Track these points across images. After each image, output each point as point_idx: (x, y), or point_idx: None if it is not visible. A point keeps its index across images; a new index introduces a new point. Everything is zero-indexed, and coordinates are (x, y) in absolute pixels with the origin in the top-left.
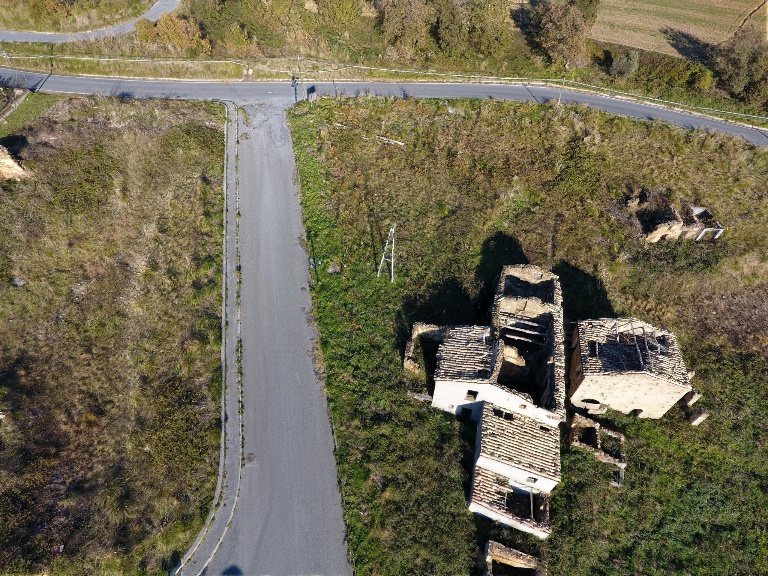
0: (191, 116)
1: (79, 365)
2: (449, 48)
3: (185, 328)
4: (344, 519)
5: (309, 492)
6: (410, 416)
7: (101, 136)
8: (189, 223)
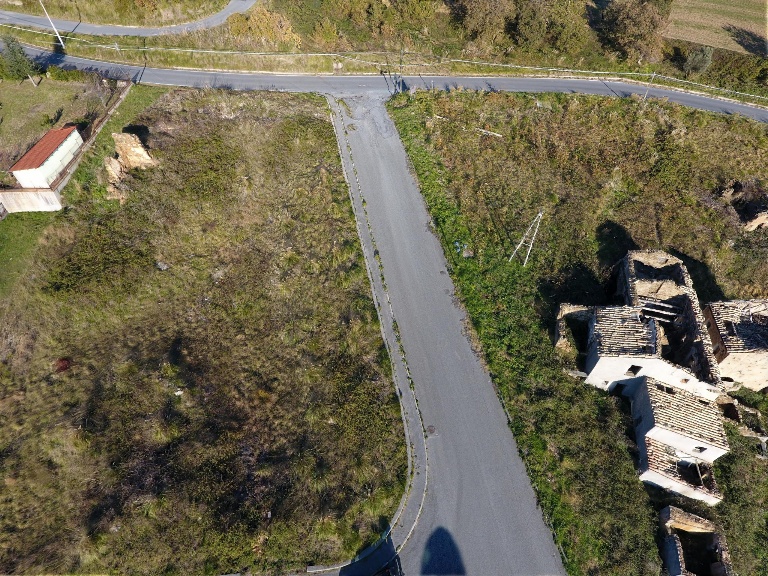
0: (299, 108)
1: (236, 345)
2: (526, 44)
3: (341, 309)
4: (533, 486)
5: (494, 461)
6: (569, 391)
7: (216, 126)
8: (320, 210)
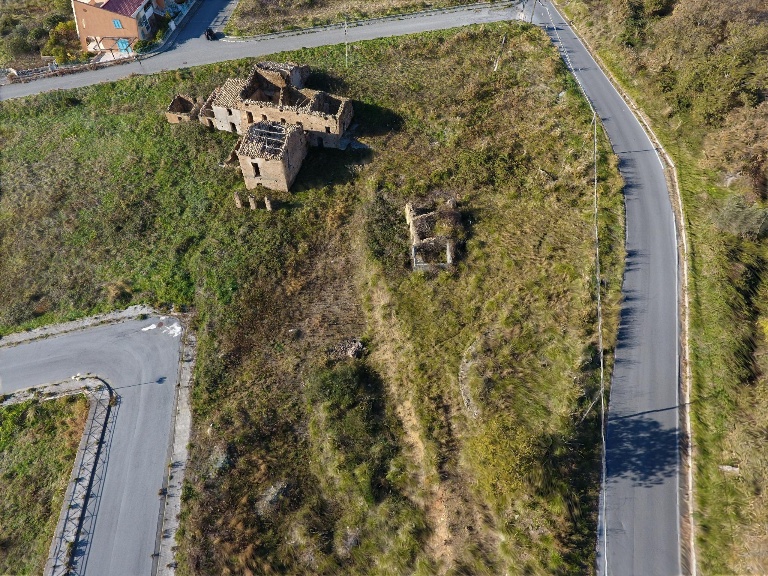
0: None
1: None
2: None
3: None
4: None
5: (240, 54)
6: None
7: None
8: None
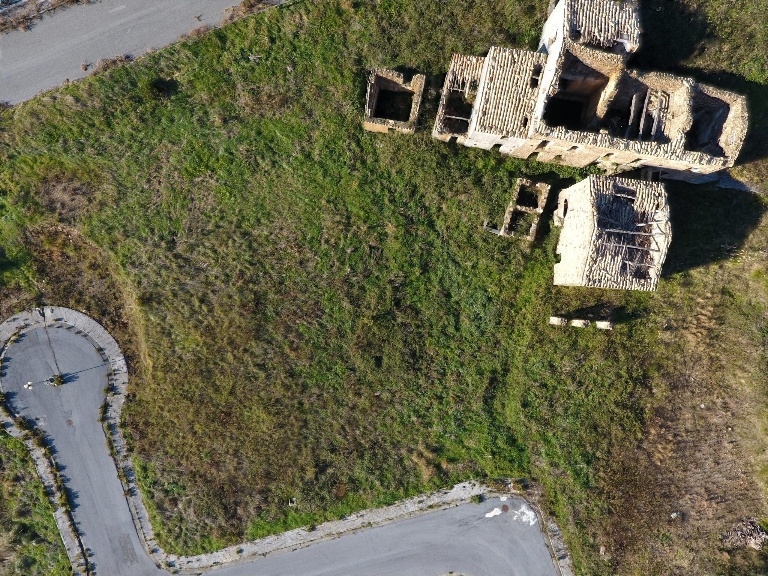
0: None
1: None
2: None
3: None
4: None
5: None
6: None
7: None
8: None
